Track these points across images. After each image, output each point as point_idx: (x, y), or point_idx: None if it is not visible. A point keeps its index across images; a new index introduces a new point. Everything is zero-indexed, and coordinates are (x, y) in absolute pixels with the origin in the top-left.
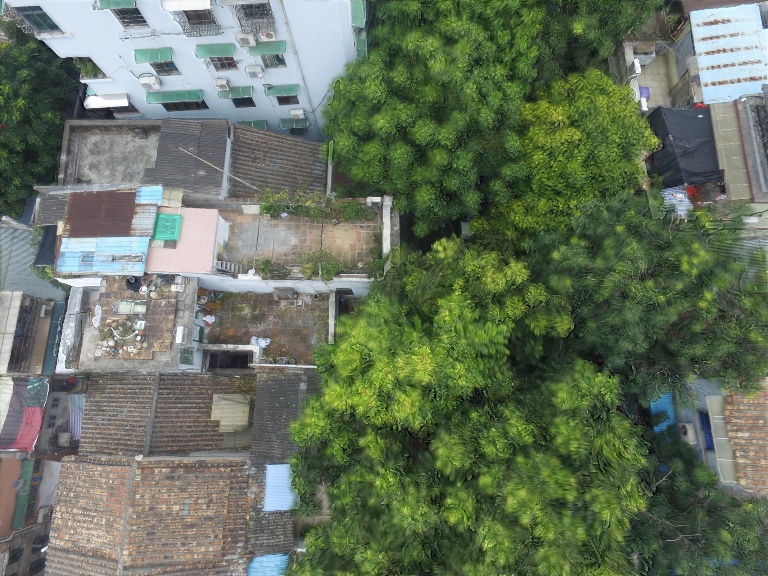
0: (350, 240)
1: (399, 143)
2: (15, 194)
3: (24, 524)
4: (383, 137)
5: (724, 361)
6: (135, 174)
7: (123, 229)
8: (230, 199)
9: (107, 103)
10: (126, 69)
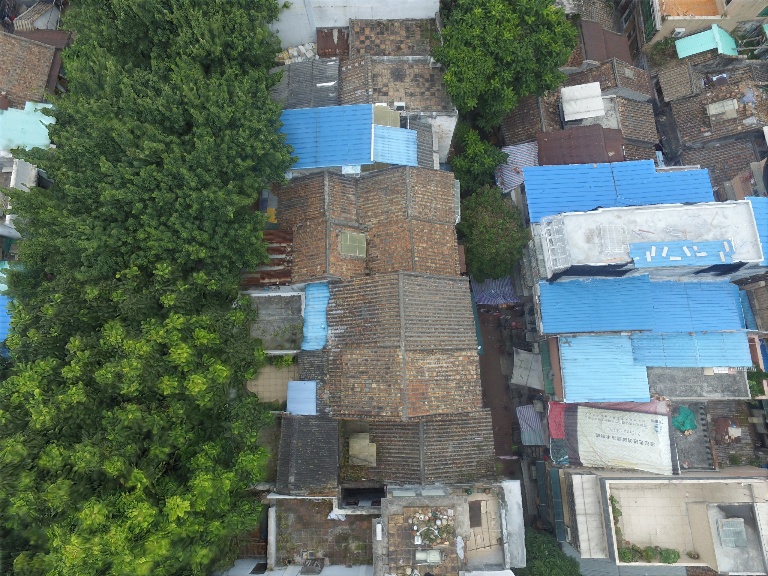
0: None
1: None
2: None
3: None
4: None
5: None
6: None
7: None
8: None
9: None
10: None
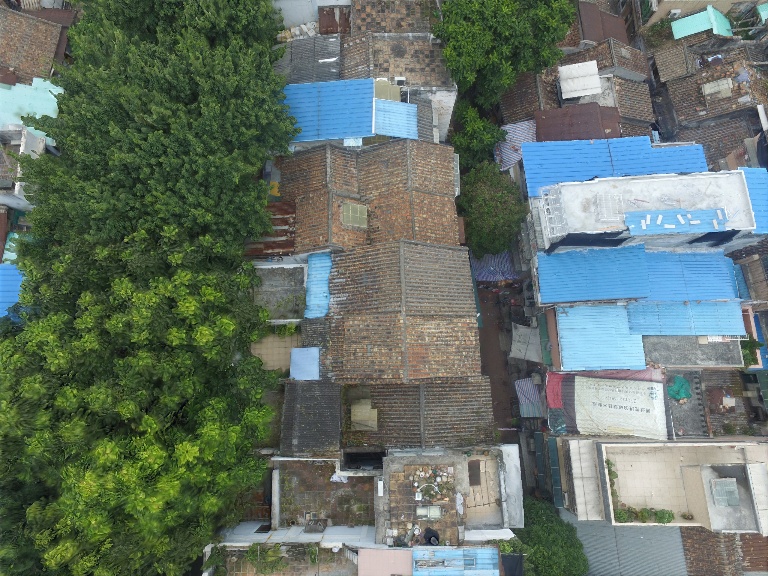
0: None
1: None
2: None
3: None
4: None
5: None
6: None
7: None
8: None
9: None
10: None
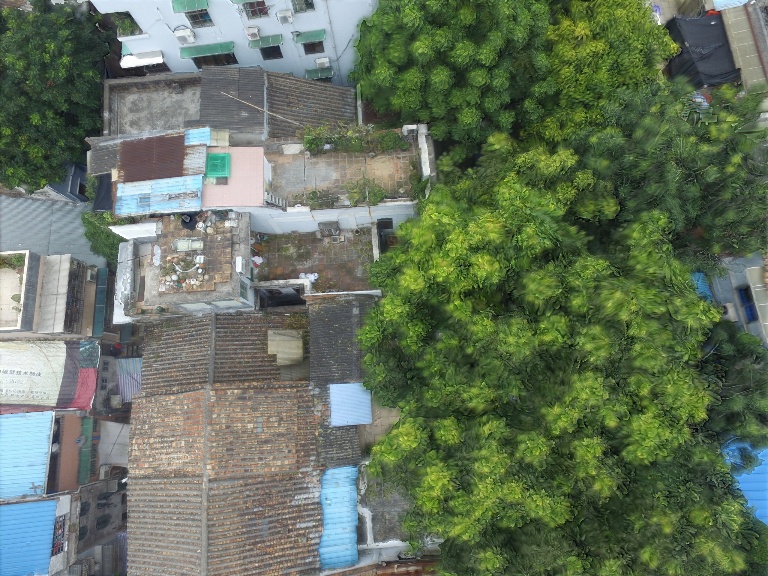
0: (388, 171)
1: (433, 66)
2: (60, 156)
3: (89, 478)
4: (419, 59)
5: (761, 231)
6: (175, 127)
7: (176, 170)
8: (271, 140)
9: (143, 61)
10: (163, 22)
